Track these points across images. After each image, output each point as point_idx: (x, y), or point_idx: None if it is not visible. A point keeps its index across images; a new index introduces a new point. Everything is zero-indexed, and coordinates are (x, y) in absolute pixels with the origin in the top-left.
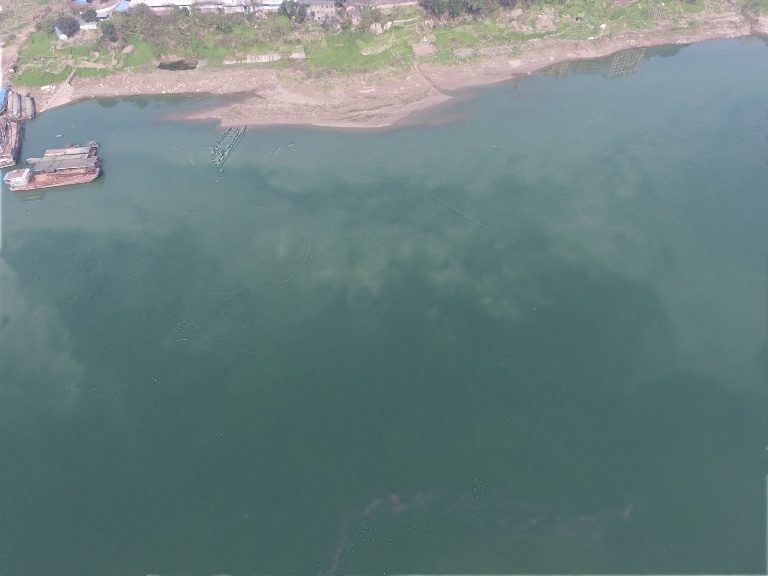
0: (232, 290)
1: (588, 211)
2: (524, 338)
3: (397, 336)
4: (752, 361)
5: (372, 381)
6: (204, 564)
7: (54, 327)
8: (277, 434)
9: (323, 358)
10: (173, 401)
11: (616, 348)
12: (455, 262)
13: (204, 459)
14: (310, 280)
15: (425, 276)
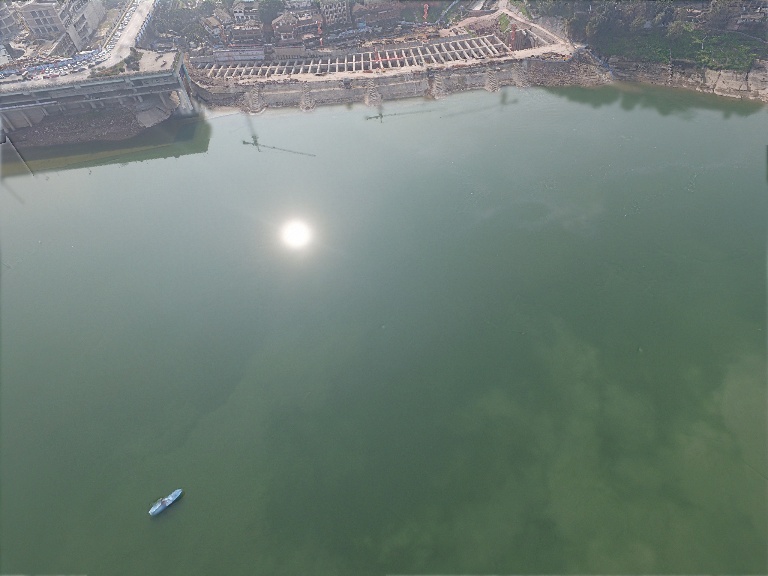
0: None
1: (616, 550)
2: None
3: (760, 297)
4: None
5: None
6: (761, 172)
7: None
8: None
9: None
10: None
11: (562, 300)
12: (764, 409)
13: None
14: None
15: None
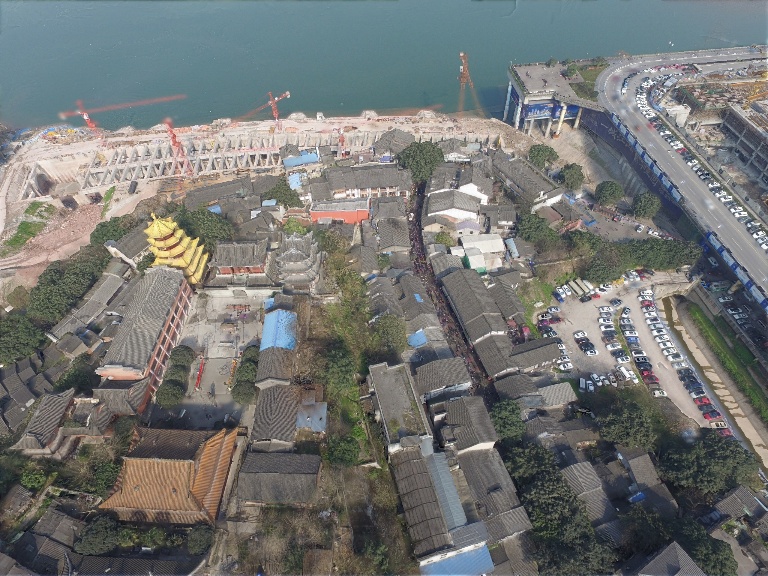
0: (86, 8)
1: None
2: (208, 4)
3: (156, 11)
4: (303, 7)
5: (138, 18)
6: None
7: (0, 16)
8: (94, 31)
9: (118, 13)
10: (52, 28)
11: (244, 3)
12: None
13: (63, 37)
14: (125, 5)
15: (180, 0)
